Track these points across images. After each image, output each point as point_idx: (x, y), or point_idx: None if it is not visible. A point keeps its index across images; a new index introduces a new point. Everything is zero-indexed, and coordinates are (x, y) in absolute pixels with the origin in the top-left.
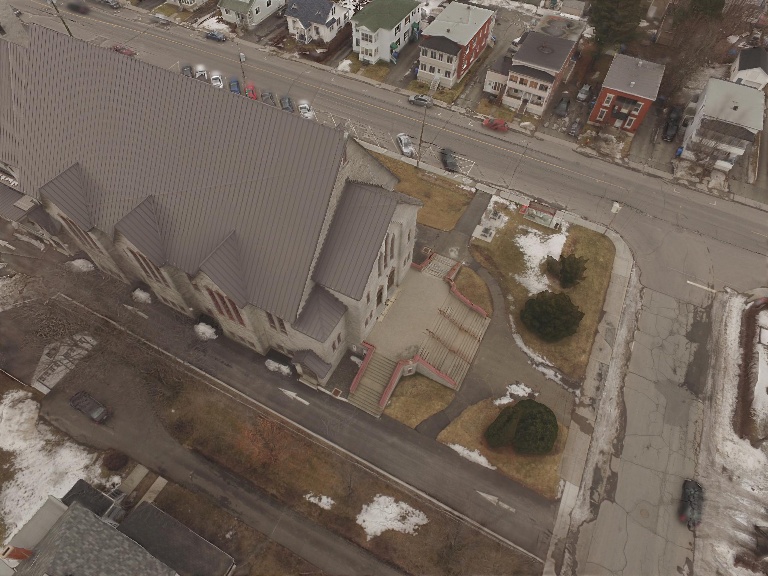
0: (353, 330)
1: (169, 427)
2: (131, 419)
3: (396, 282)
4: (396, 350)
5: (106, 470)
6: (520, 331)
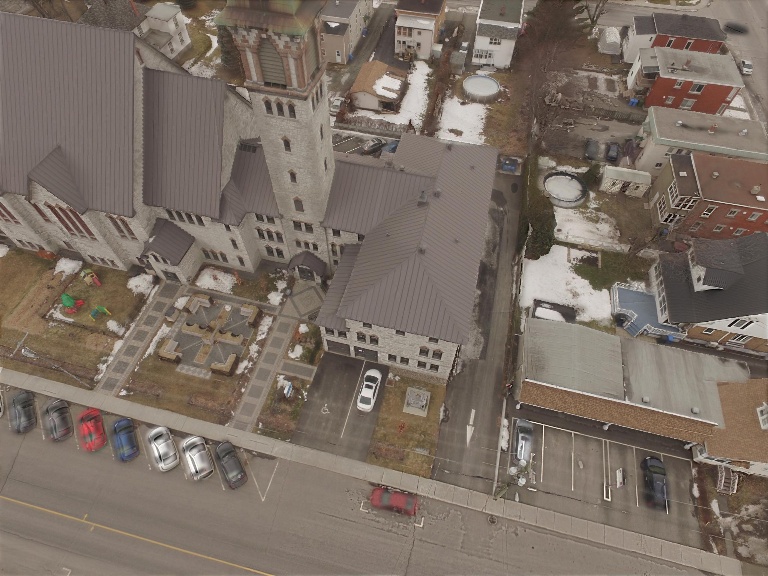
0: None
1: None
2: None
3: None
4: None
5: None
6: None
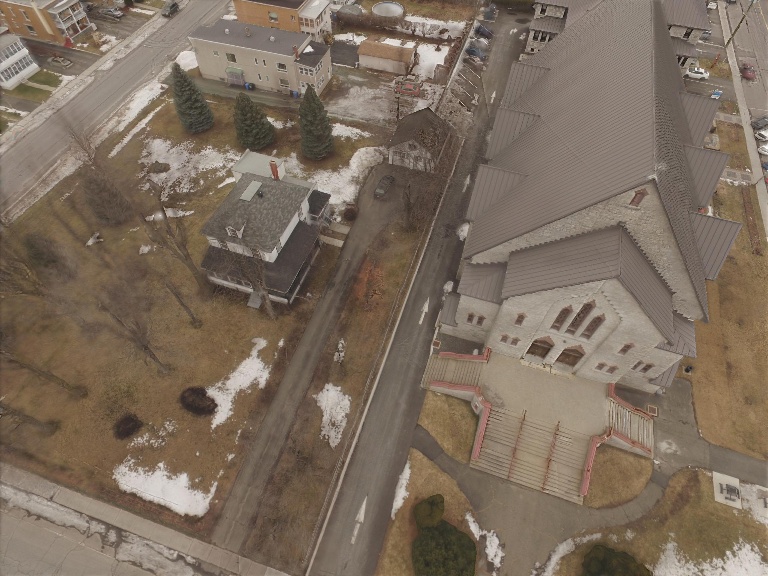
0: (492, 329)
1: (380, 235)
2: (381, 212)
3: (577, 369)
4: (492, 384)
5: (344, 212)
6: (580, 550)
